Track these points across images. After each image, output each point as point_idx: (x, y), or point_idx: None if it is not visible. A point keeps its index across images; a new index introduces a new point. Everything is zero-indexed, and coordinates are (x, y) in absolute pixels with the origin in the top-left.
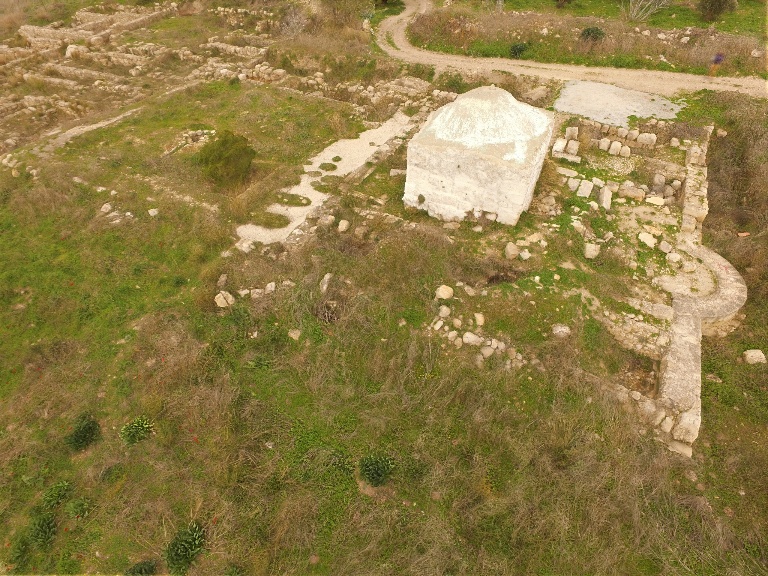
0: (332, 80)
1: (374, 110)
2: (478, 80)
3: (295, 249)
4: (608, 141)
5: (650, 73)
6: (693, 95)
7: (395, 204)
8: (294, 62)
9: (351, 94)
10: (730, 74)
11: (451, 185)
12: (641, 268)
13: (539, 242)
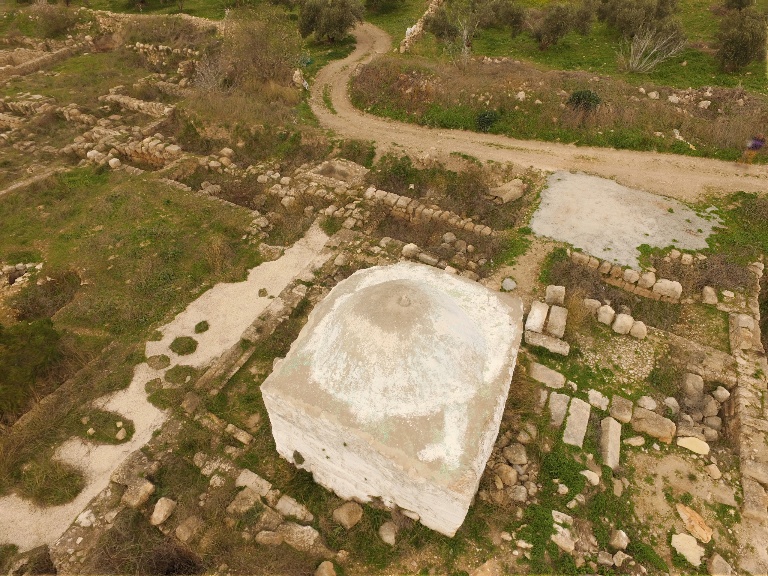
0: (242, 160)
1: (282, 220)
2: (432, 166)
3: (66, 571)
4: (611, 313)
5: (662, 158)
6: (726, 201)
7: (268, 439)
8: (200, 130)
9: (258, 189)
10: None
11: (339, 459)
12: None
13: None
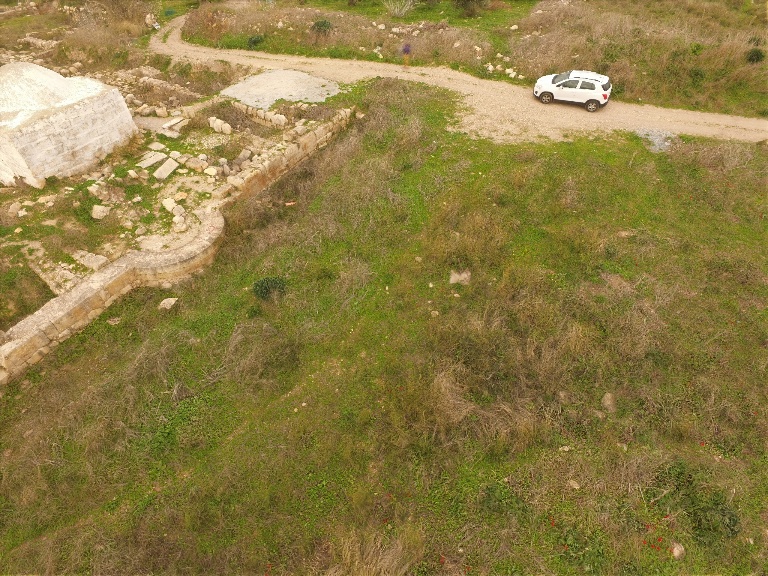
0: (86, 70)
1: None
2: (203, 69)
3: None
4: (212, 119)
5: (357, 63)
6: (366, 82)
7: None
8: (68, 54)
9: None
10: (427, 64)
11: None
12: (135, 228)
13: (46, 203)
